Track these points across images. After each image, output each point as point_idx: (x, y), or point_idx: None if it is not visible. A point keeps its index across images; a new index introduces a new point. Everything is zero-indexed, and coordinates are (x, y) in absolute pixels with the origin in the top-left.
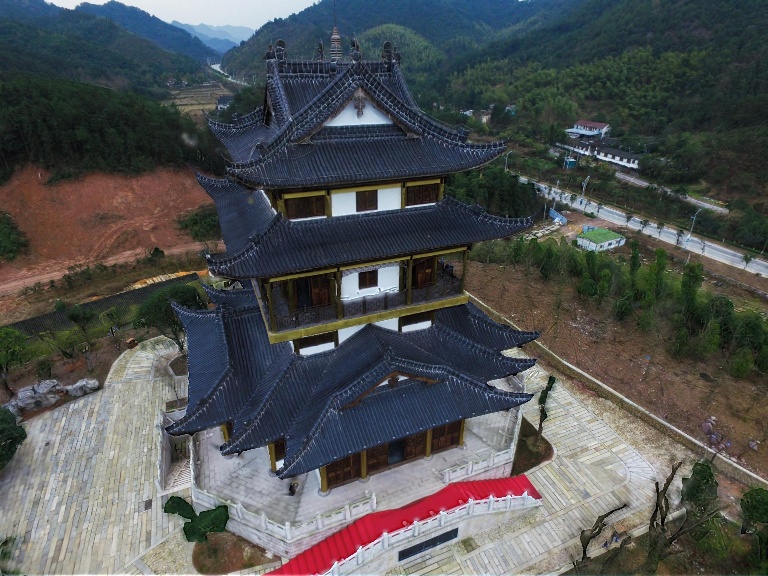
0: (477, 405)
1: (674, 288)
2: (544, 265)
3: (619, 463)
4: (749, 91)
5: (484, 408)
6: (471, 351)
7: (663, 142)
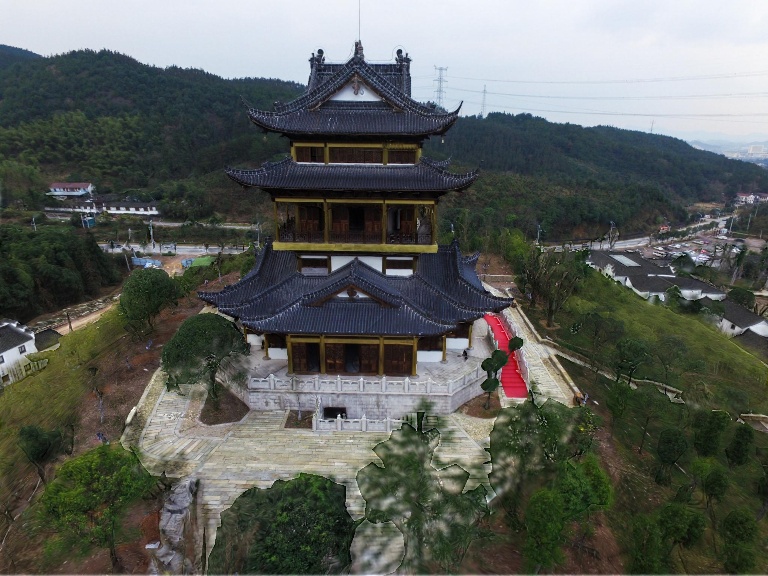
0: None
1: None
2: None
3: None
4: (190, 147)
5: (473, 267)
6: None
7: (162, 190)
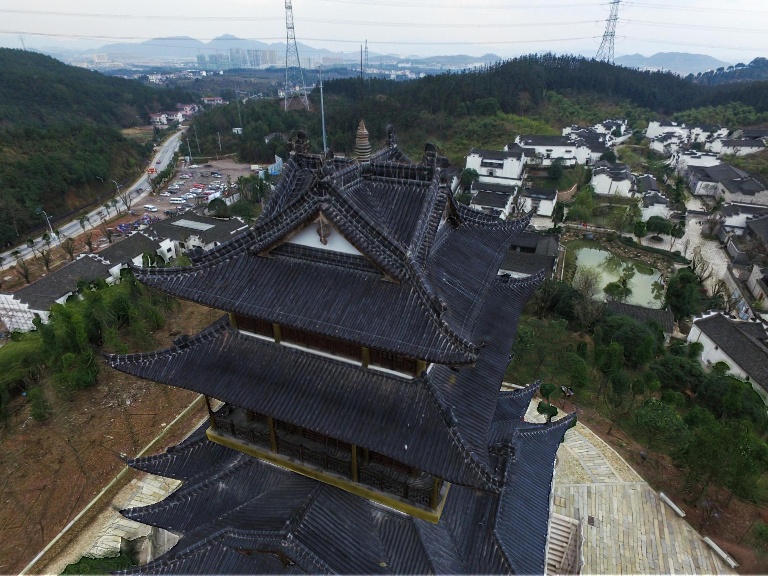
0: None
1: (29, 349)
2: None
3: None
4: None
5: None
6: None
7: None
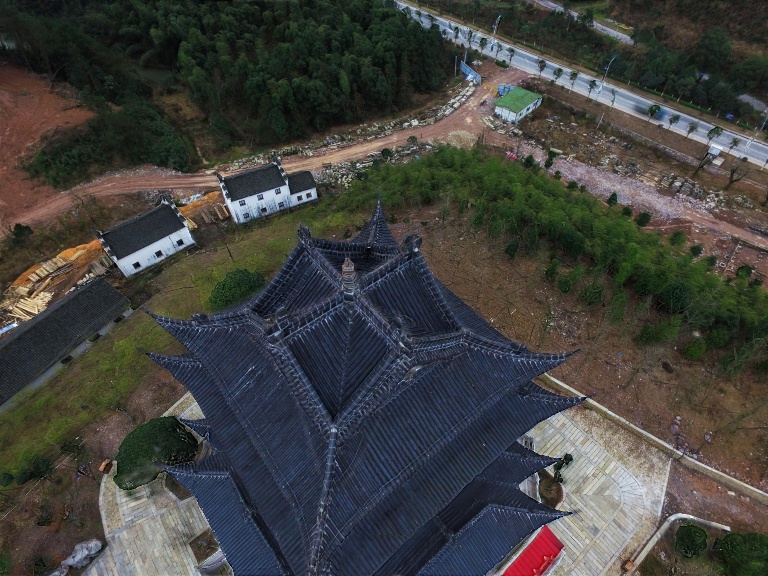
0: (522, 528)
1: None
2: (510, 246)
3: (613, 485)
4: None
5: (529, 529)
6: (500, 457)
7: None
